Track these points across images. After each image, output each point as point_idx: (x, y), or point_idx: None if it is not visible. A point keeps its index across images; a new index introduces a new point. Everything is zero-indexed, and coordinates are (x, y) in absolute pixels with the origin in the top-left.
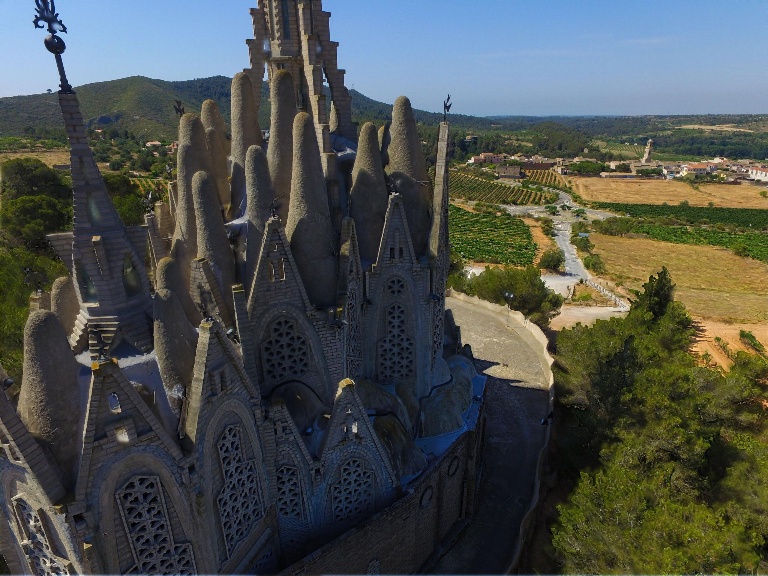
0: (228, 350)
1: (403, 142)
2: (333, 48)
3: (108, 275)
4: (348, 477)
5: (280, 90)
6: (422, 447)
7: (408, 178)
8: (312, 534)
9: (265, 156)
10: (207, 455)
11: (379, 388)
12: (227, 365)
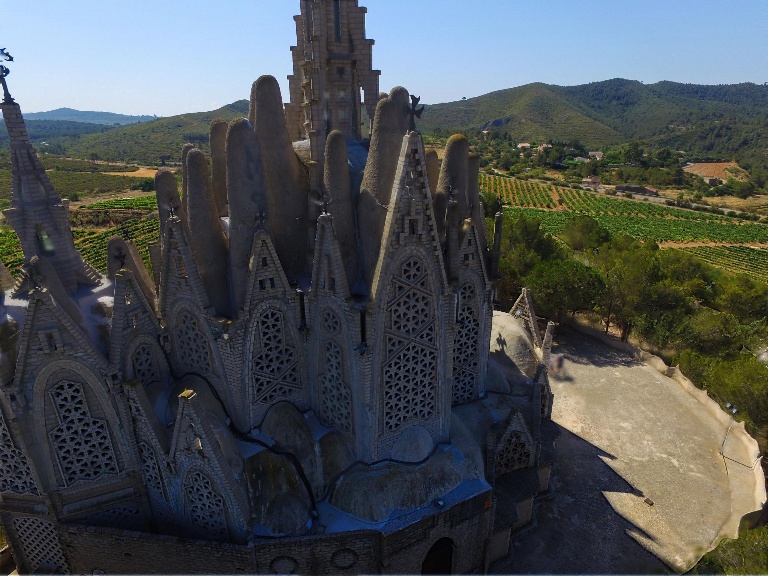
0: (59, 318)
1: (374, 154)
2: (366, 46)
3: (22, 237)
4: (200, 488)
5: (258, 96)
6: (326, 514)
7: (372, 198)
8: (176, 520)
9: (199, 159)
10: (38, 394)
11: (298, 424)
12: (57, 330)
